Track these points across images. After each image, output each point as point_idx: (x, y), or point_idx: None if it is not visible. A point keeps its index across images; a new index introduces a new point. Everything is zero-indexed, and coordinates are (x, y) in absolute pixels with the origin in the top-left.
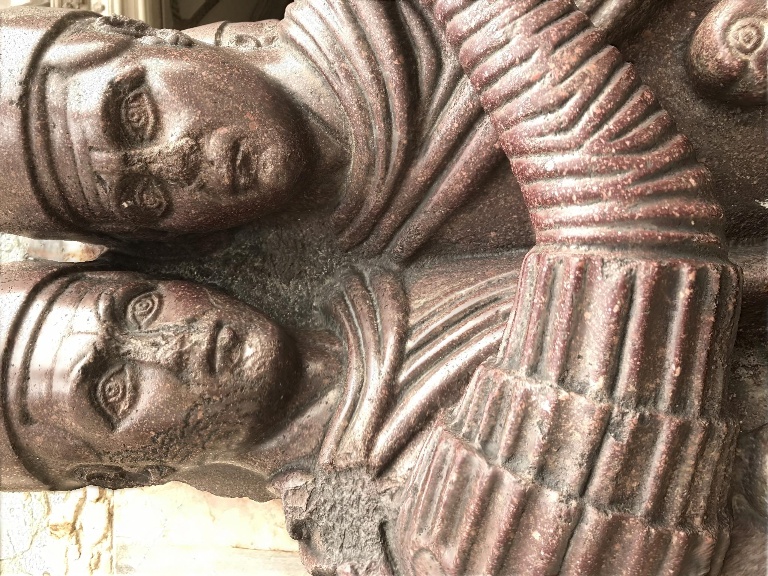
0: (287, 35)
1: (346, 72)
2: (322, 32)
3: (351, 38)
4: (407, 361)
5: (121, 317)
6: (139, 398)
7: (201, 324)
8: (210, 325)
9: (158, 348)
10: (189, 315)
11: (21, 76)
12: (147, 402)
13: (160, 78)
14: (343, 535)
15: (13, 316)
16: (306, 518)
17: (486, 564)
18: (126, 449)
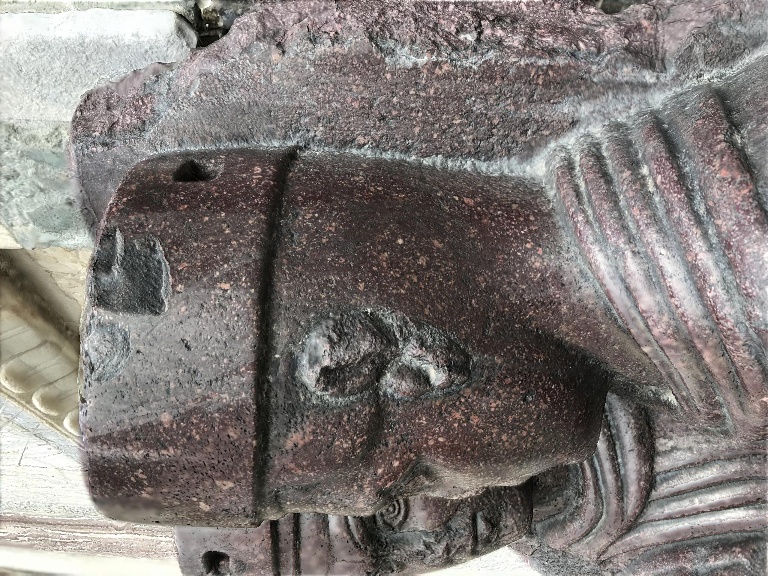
0: (620, 318)
1: (715, 416)
2: (702, 382)
3: (755, 424)
4: (648, 507)
5: (374, 528)
6: (405, 569)
7: (458, 525)
8: (468, 526)
9: (424, 556)
10: (444, 518)
11: (245, 513)
12: (414, 572)
13: (445, 462)
14: (562, 571)
15: (269, 560)
16: None
17: None
18: None
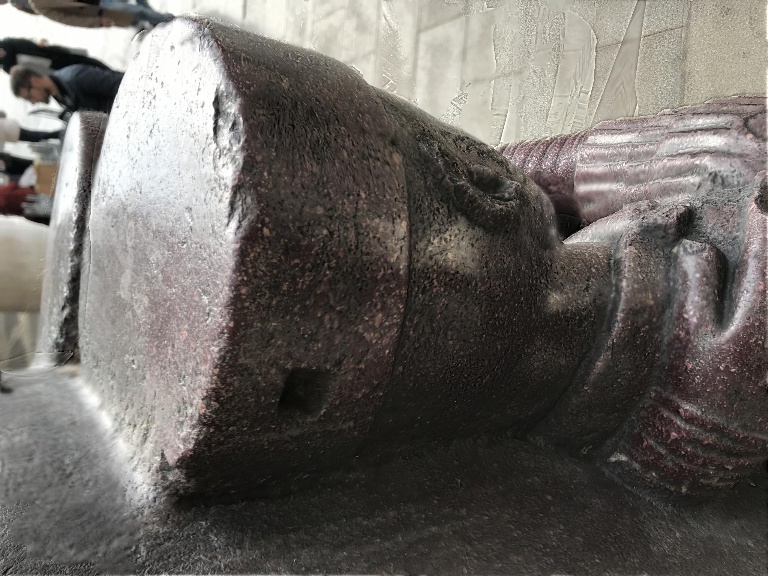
0: None
1: None
2: None
3: None
4: None
5: None
6: None
7: None
8: None
9: None
10: None
11: None
12: None
13: None
14: None
15: None
16: (685, 207)
17: (765, 99)
18: (466, 136)
